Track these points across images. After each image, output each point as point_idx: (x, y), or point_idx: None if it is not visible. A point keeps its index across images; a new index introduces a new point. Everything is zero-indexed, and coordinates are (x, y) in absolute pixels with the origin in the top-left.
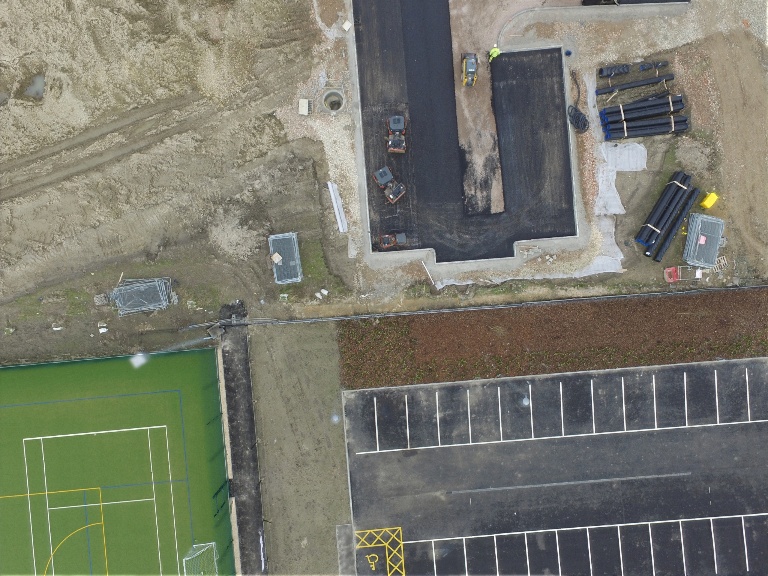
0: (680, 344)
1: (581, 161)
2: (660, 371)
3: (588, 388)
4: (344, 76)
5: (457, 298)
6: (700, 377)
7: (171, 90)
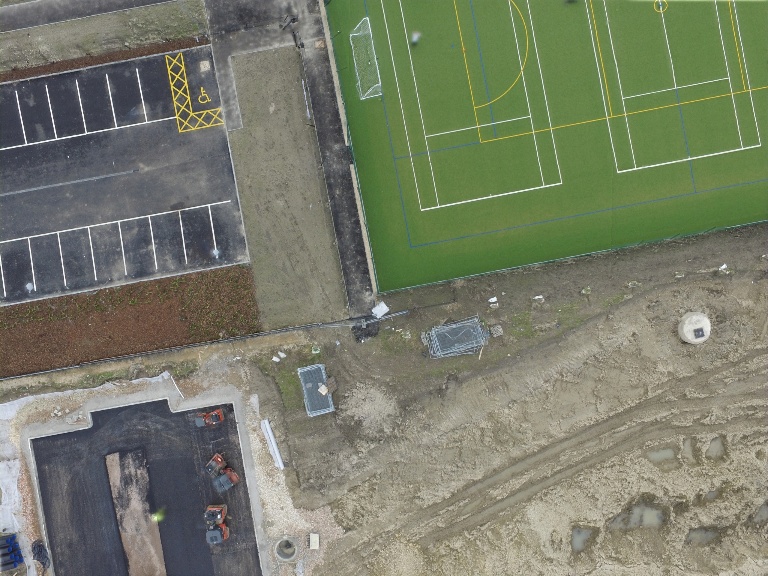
0: None
1: (35, 513)
2: None
3: (8, 288)
4: (278, 575)
5: (146, 365)
6: None
7: (448, 547)
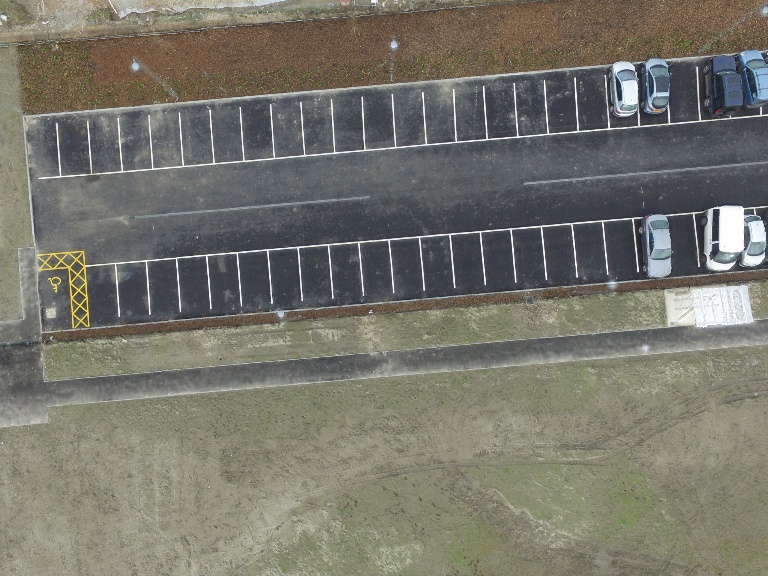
0: (355, 66)
1: None
2: (338, 95)
3: (267, 113)
4: None
5: (138, 25)
6: (377, 101)
7: None
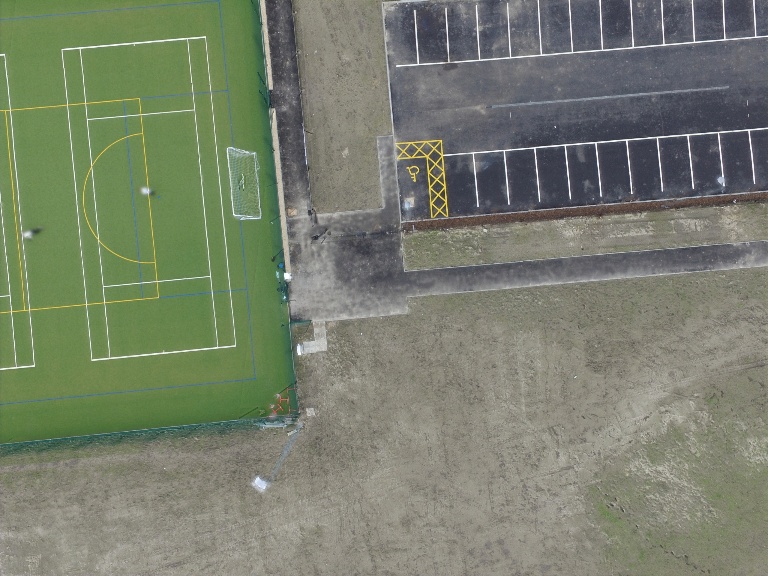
0: None
1: None
2: None
3: (627, 1)
4: None
5: None
6: None
7: None
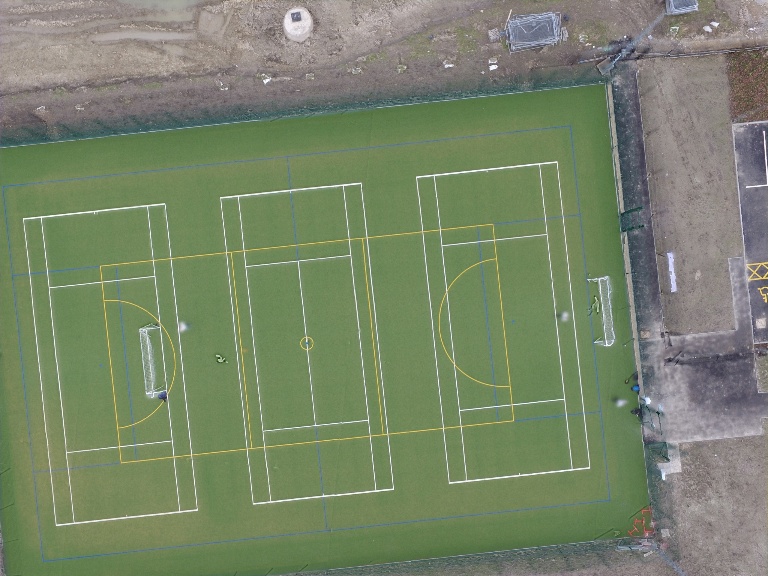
0: None
1: None
2: None
3: None
4: None
5: None
6: None
7: None
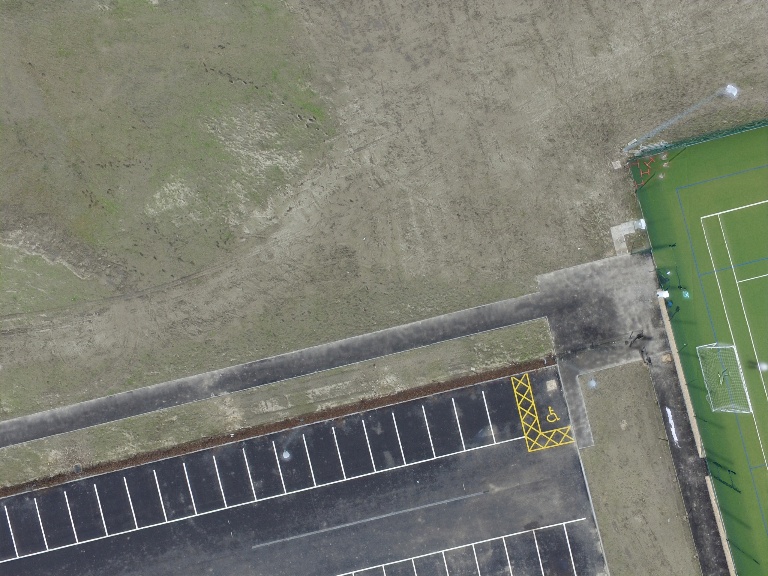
0: None
1: None
2: None
3: None
4: None
5: None
6: None
7: None
